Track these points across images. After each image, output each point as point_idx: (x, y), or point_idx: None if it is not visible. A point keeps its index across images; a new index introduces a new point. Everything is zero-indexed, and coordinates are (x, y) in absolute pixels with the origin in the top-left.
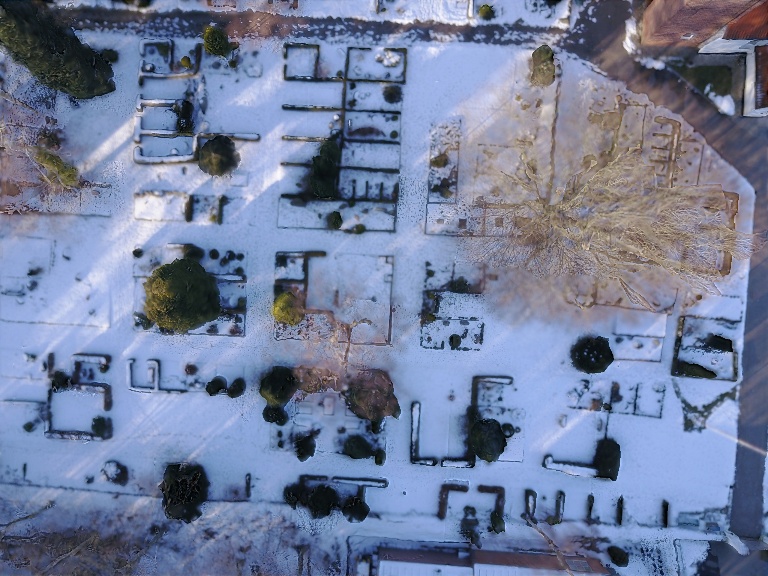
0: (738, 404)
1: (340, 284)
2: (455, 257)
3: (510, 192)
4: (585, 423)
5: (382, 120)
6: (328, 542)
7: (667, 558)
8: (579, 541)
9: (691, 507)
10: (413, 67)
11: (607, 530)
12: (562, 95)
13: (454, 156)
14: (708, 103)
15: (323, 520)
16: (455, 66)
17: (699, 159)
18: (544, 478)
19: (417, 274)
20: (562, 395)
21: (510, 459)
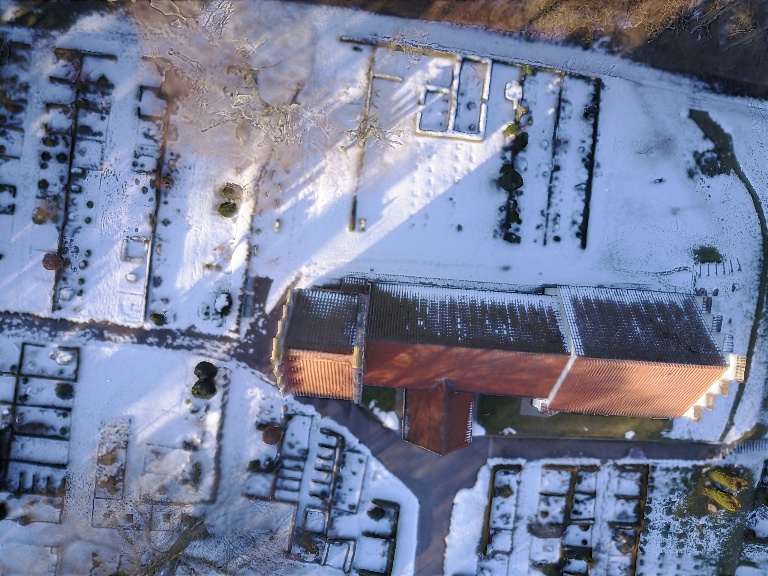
0: None
1: (5, 571)
2: (122, 549)
3: (176, 491)
4: None
5: (53, 415)
6: None
7: None
8: None
9: None
10: (86, 365)
11: None
12: (230, 402)
13: (122, 454)
14: (373, 417)
15: None
16: (127, 367)
17: (363, 469)
18: None
19: (83, 564)
20: None
21: None
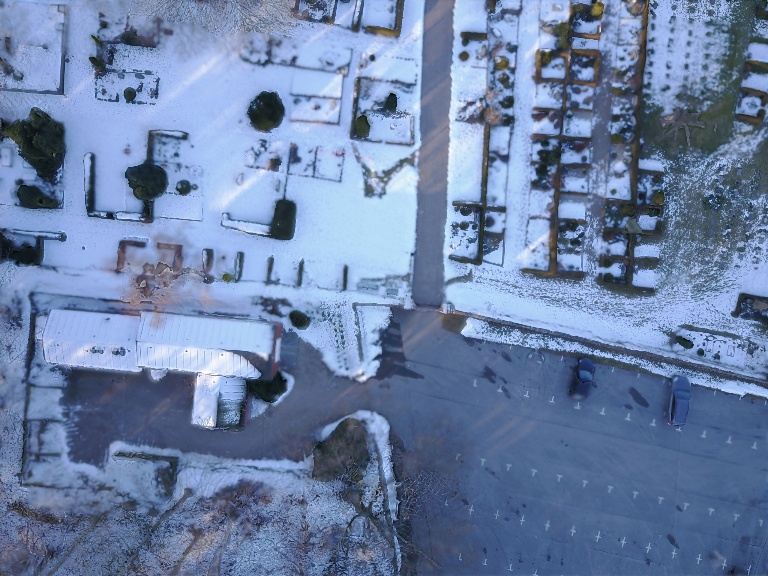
0: (417, 170)
1: (13, 32)
2: (129, 10)
3: None
4: (263, 183)
5: None
6: (8, 295)
7: (347, 322)
8: (260, 303)
9: (373, 273)
10: None
11: (285, 291)
12: None
13: None
14: None
15: (1, 271)
16: None
17: None
18: (225, 239)
19: (90, 25)
20: (240, 154)
21: (189, 217)
